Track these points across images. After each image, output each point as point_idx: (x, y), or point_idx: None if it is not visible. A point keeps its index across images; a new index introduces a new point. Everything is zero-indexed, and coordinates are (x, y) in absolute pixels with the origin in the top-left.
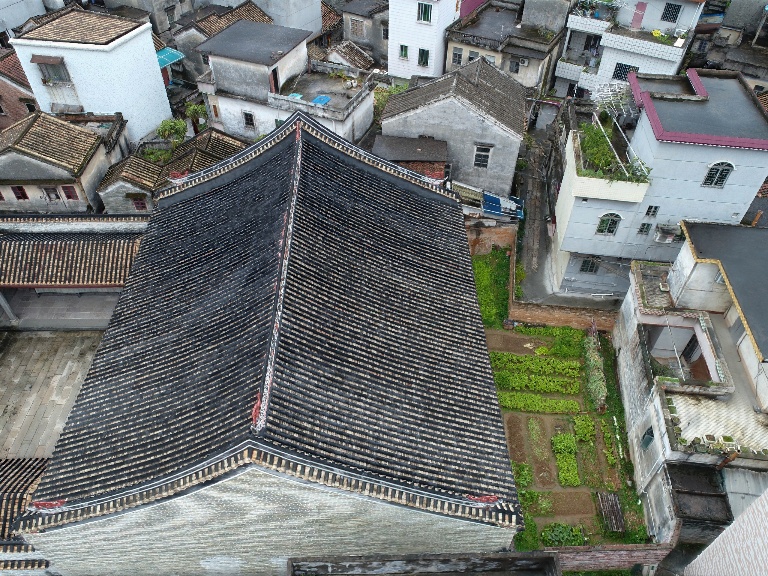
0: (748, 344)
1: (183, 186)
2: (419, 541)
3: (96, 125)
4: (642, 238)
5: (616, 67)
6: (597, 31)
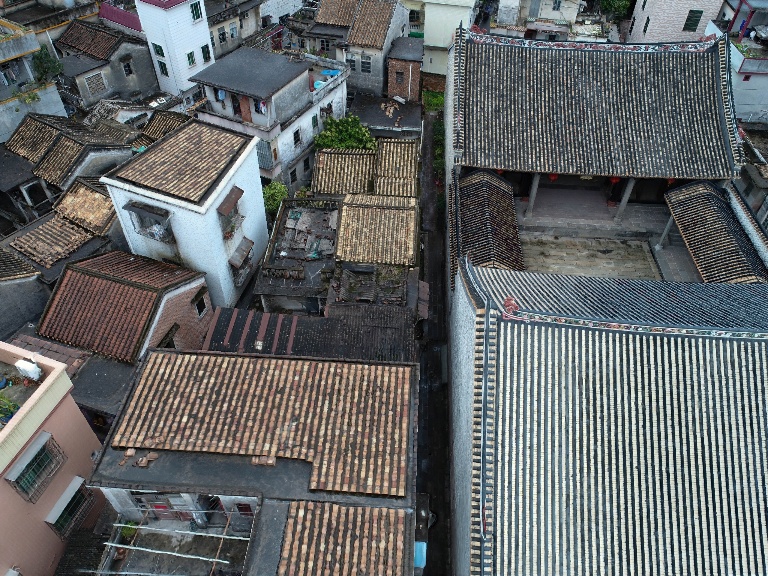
0: (546, 12)
1: (461, 126)
2: None
3: (292, 222)
4: None
5: None
6: None
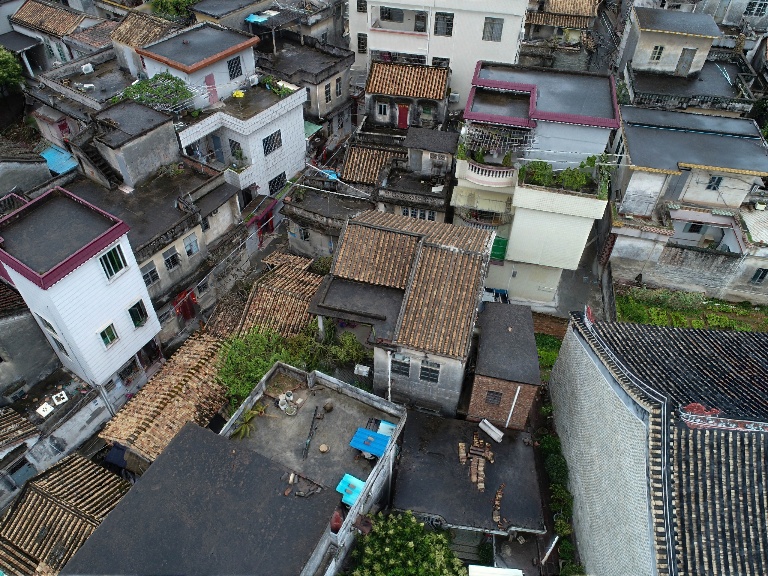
0: (694, 191)
1: None
2: None
3: None
4: None
5: (263, 144)
6: (212, 129)
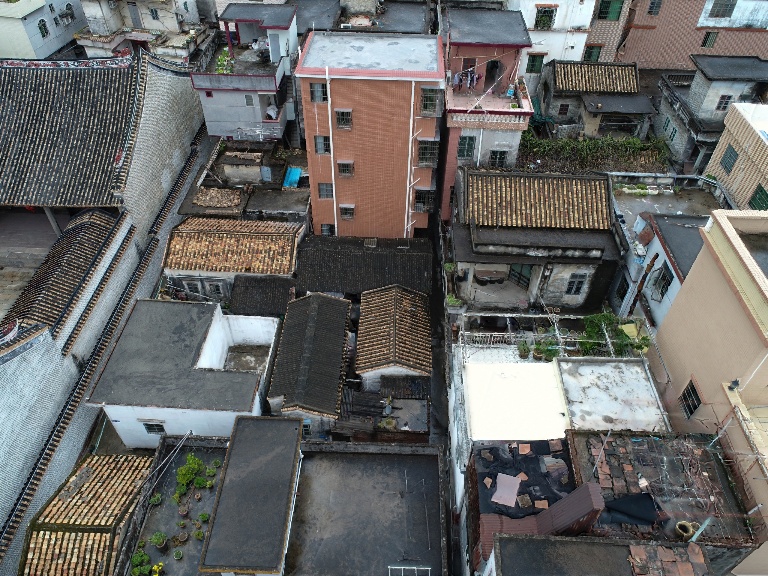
0: (147, 22)
1: None
2: (189, 107)
3: None
4: (60, 28)
5: None
6: None
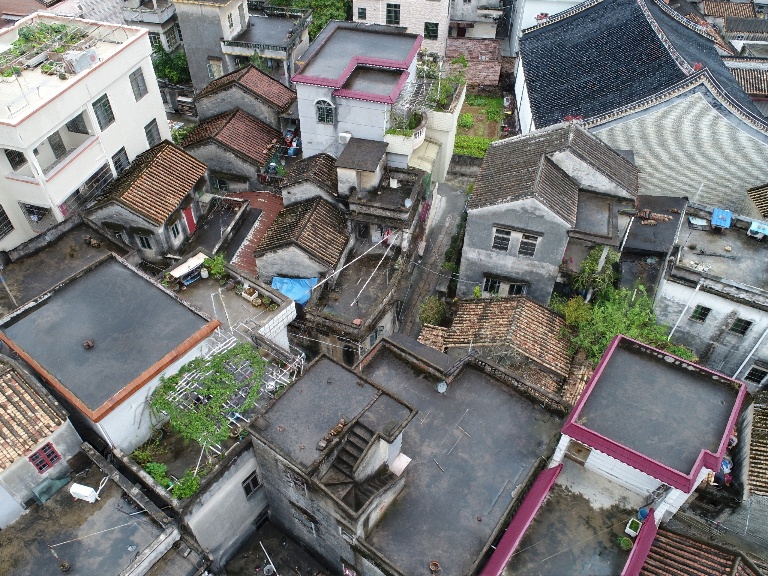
0: None
1: None
2: None
3: None
4: None
5: None
6: None
